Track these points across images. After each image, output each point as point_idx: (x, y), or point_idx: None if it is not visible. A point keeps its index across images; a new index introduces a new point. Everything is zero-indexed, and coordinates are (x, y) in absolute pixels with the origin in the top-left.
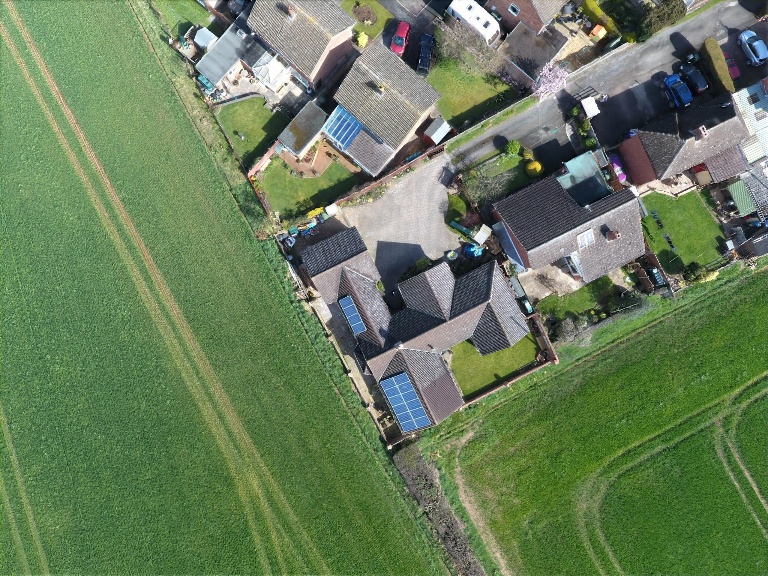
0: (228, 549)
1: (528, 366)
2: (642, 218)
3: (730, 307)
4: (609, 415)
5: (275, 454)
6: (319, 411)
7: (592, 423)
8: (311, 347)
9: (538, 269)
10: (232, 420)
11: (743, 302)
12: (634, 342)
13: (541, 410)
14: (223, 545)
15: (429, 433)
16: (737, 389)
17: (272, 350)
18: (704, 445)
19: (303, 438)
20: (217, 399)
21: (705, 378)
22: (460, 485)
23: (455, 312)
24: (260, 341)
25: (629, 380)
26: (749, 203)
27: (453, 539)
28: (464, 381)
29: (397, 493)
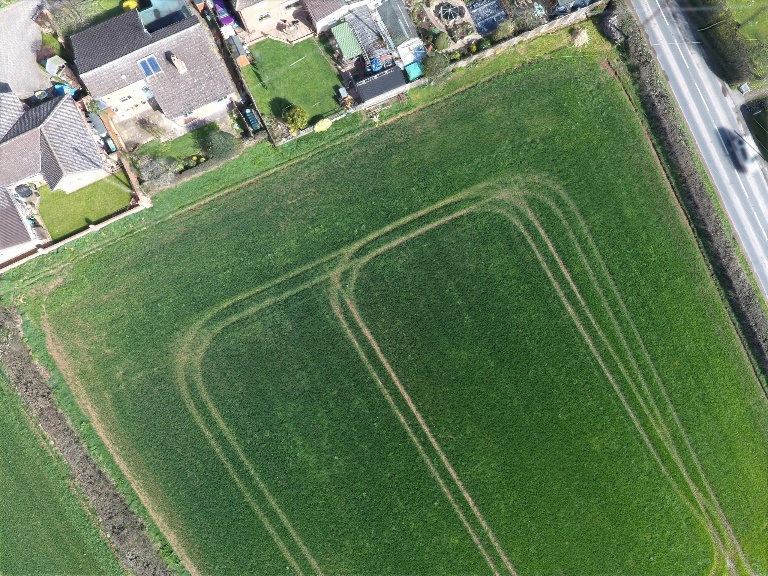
0: None
1: (121, 211)
2: (254, 64)
3: (350, 159)
4: (213, 265)
5: None
6: None
7: (193, 273)
8: None
9: (140, 113)
10: None
11: (363, 154)
12: (244, 192)
13: (138, 258)
14: None
15: (11, 277)
16: (356, 243)
17: None
18: (318, 300)
19: None
20: None
21: (319, 230)
22: (47, 333)
23: (6, 138)
24: None
25: (236, 230)
26: (354, 46)
27: (23, 383)
28: (52, 225)
29: None
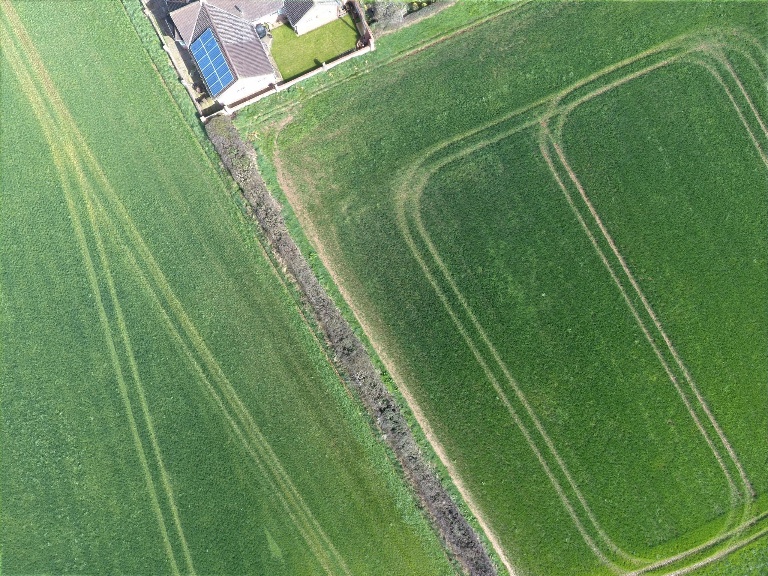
0: (42, 214)
1: (348, 52)
2: None
3: (558, 9)
4: (431, 107)
5: (91, 126)
6: (136, 86)
7: (413, 114)
8: (129, 23)
9: None
10: (49, 91)
11: (571, 4)
12: (459, 39)
13: (362, 99)
14: (37, 210)
15: (247, 113)
16: (563, 90)
17: (91, 25)
18: (528, 143)
19: (120, 112)
20: (35, 70)
21: (530, 76)
22: (278, 168)
23: None
24: (79, 16)
25: (452, 74)
26: None
27: (264, 209)
28: (284, 65)
29: (213, 170)
